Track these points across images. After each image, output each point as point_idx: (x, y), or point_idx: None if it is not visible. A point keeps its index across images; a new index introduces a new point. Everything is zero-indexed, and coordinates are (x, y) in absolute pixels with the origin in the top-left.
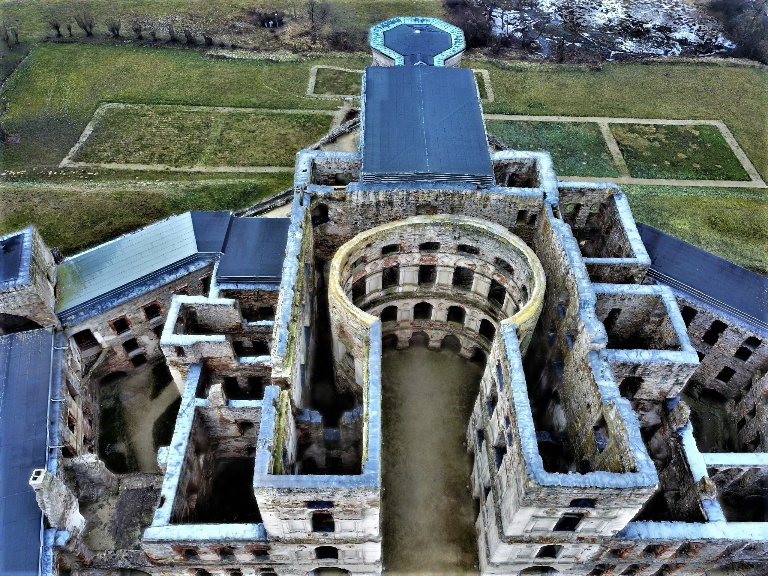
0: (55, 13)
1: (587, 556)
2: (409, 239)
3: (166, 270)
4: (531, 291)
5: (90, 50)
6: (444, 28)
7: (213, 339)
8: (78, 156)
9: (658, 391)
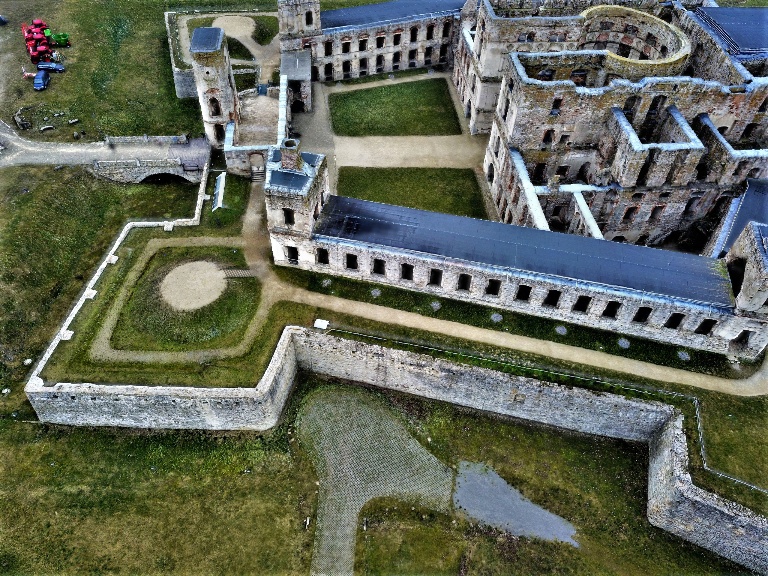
0: None
1: (501, 168)
2: (661, 37)
3: None
4: None
5: None
6: None
7: None
8: None
9: None
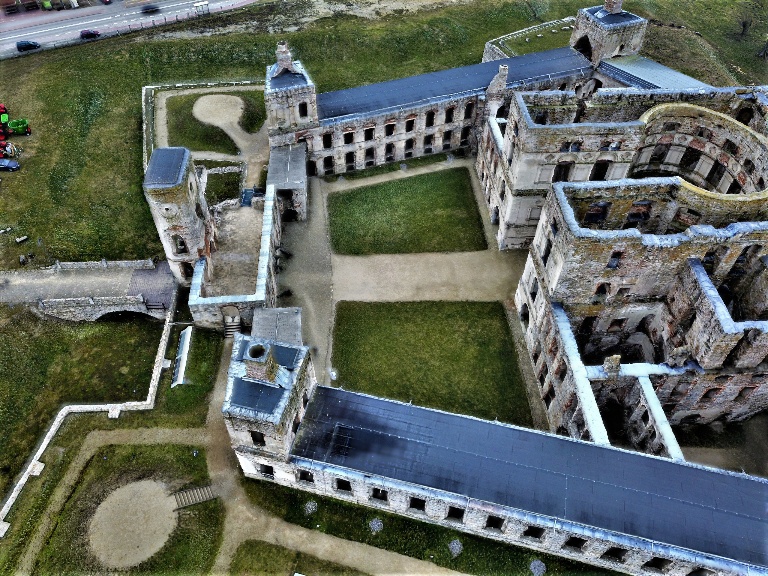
0: None
1: None
2: (744, 148)
3: None
4: None
5: None
6: None
7: None
8: None
9: (697, 344)
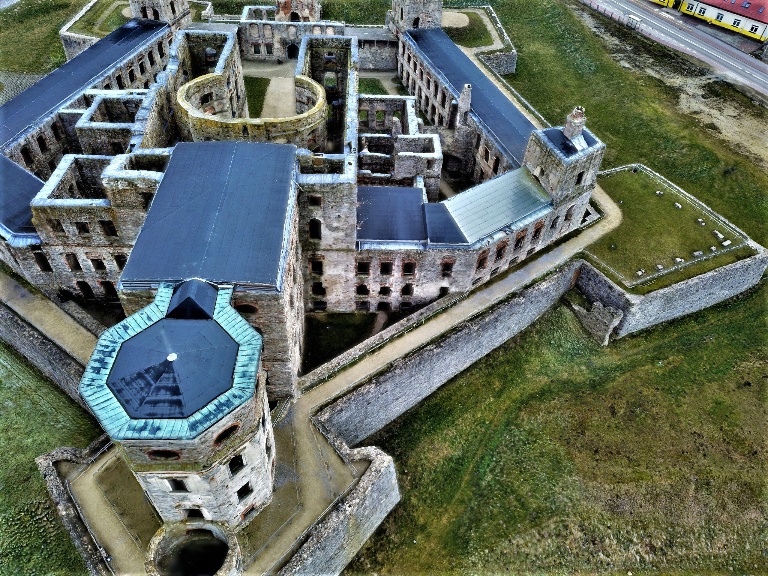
0: None
1: None
2: None
3: None
4: None
5: None
6: (110, 401)
7: (405, 135)
8: None
9: None
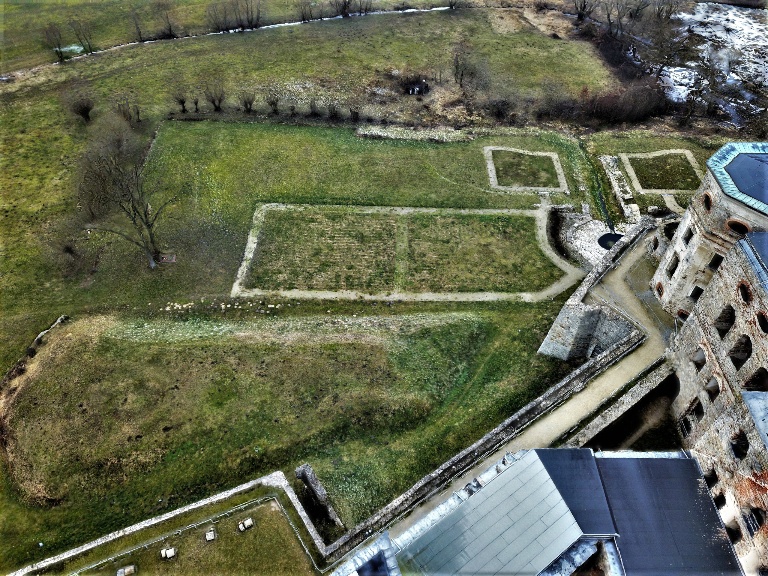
0: (171, 81)
1: None
2: None
3: (547, 567)
4: None
5: (224, 130)
6: None
7: None
8: (250, 280)
9: None
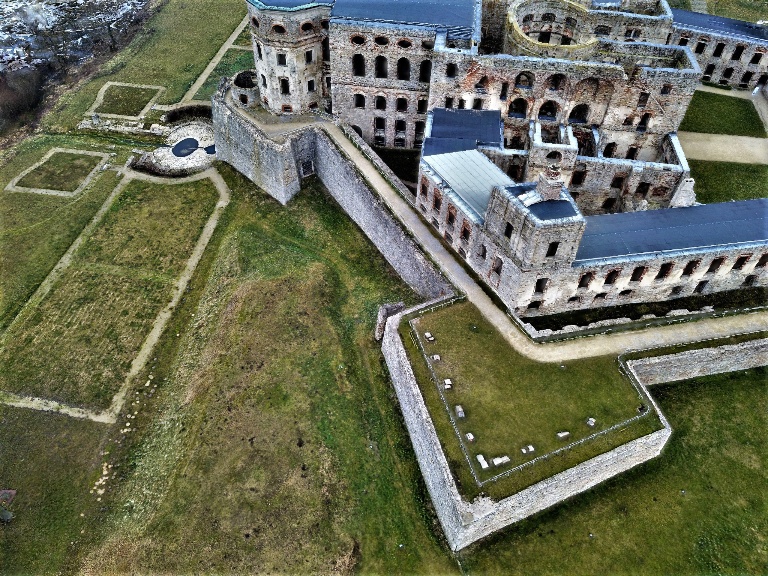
0: None
1: None
2: None
3: None
4: (559, 6)
5: None
6: None
7: (571, 130)
8: (97, 404)
9: None
